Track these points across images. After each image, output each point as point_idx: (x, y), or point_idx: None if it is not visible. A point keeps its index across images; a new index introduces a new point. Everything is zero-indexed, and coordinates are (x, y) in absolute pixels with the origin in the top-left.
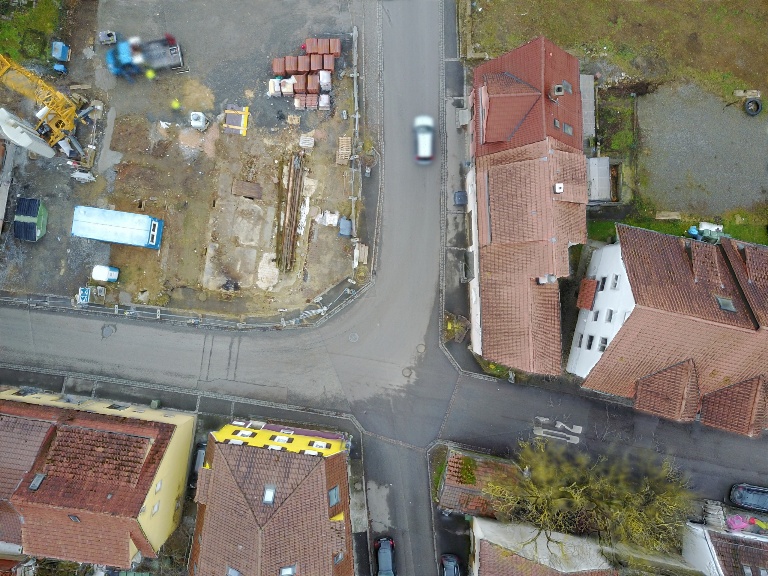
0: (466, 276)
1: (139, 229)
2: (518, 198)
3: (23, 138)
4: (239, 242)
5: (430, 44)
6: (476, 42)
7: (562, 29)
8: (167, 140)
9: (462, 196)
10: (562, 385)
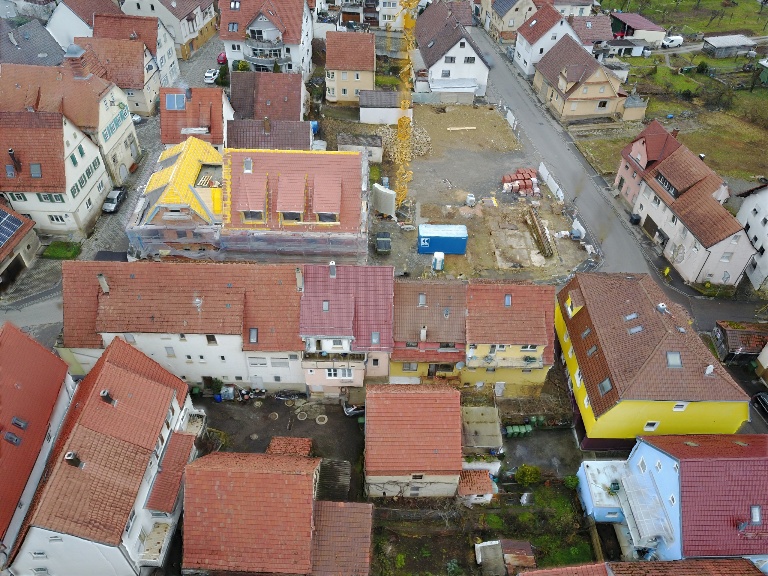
0: (664, 238)
1: (460, 230)
2: (682, 169)
3: (391, 191)
4: (513, 247)
5: (580, 172)
6: None
7: None
8: (453, 212)
9: (636, 215)
10: (759, 298)
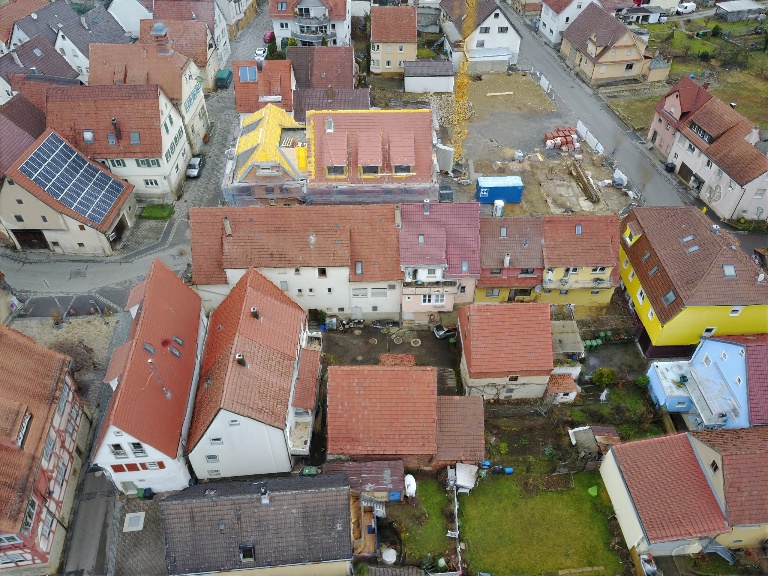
0: (700, 181)
1: (516, 181)
2: None
3: (450, 148)
4: (563, 195)
5: (614, 129)
6: None
7: None
8: (503, 167)
9: (671, 164)
10: None
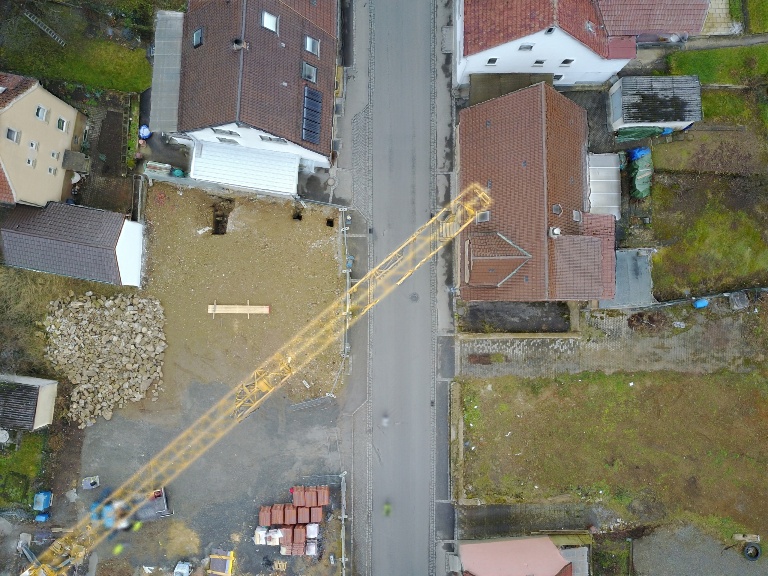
0: None
1: None
2: None
3: None
4: None
5: (421, 485)
6: (468, 483)
7: (557, 471)
8: None
9: None
10: None
